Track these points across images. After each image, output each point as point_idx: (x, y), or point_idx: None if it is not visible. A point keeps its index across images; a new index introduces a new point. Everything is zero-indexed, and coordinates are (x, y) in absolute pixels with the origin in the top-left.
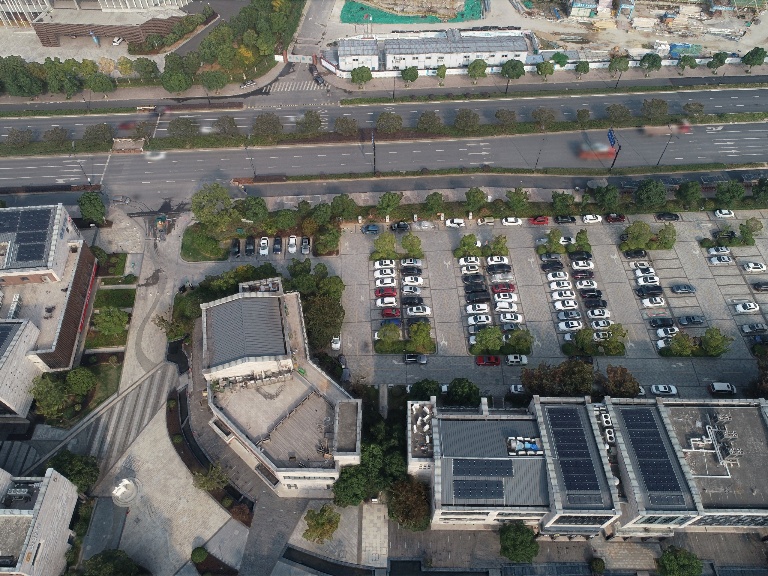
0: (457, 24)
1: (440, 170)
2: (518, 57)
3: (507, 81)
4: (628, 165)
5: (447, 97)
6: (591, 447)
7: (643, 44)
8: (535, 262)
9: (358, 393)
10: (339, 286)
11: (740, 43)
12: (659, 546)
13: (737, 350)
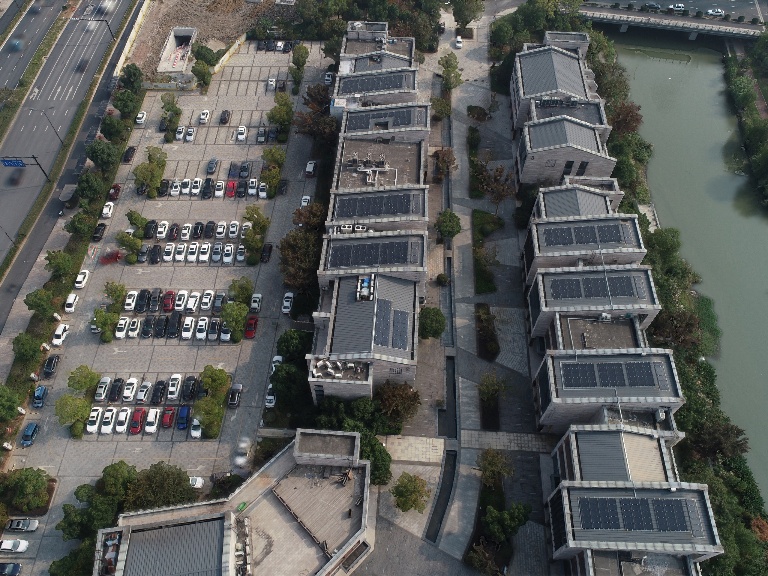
0: None
1: None
2: None
3: None
4: (48, 167)
5: None
6: (370, 242)
7: None
8: (144, 268)
9: (271, 452)
10: (123, 465)
11: None
12: (428, 239)
13: None
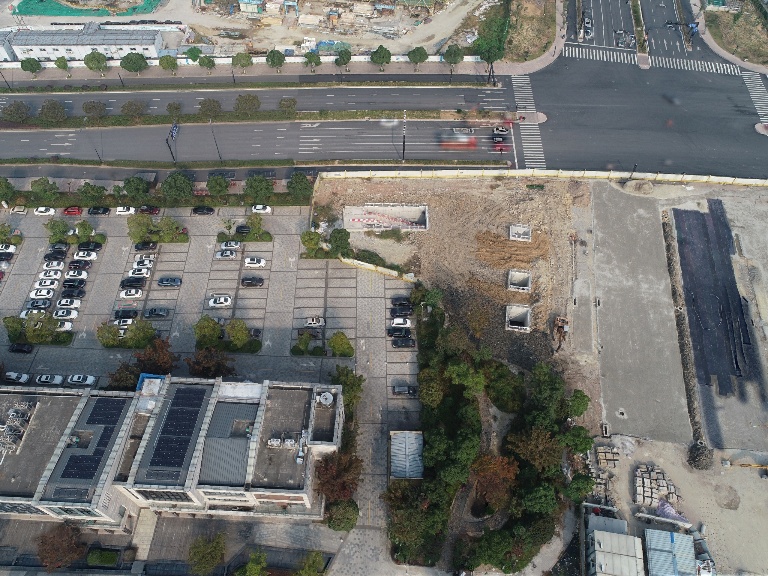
0: (124, 18)
1: (8, 159)
2: (147, 51)
3: (136, 74)
4: (200, 159)
5: (63, 88)
6: None
7: (296, 41)
8: (43, 251)
9: None
10: None
11: (396, 42)
12: None
13: (184, 343)
